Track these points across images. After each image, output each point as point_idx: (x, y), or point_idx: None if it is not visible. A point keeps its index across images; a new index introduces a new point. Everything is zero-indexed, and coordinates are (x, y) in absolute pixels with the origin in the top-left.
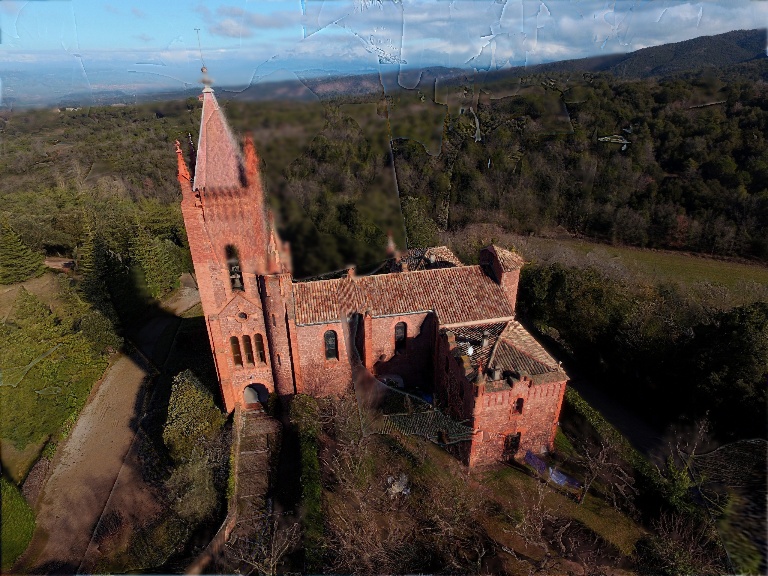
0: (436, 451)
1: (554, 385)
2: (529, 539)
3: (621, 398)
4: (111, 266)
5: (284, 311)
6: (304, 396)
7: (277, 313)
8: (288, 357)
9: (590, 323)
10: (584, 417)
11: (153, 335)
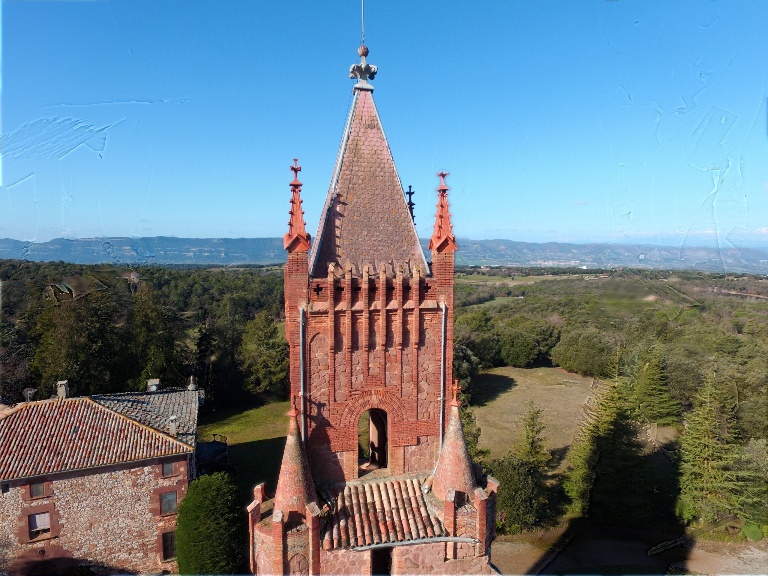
0: None
1: None
2: None
3: None
4: (619, 431)
5: None
6: None
7: None
8: None
9: None
10: None
11: (599, 557)
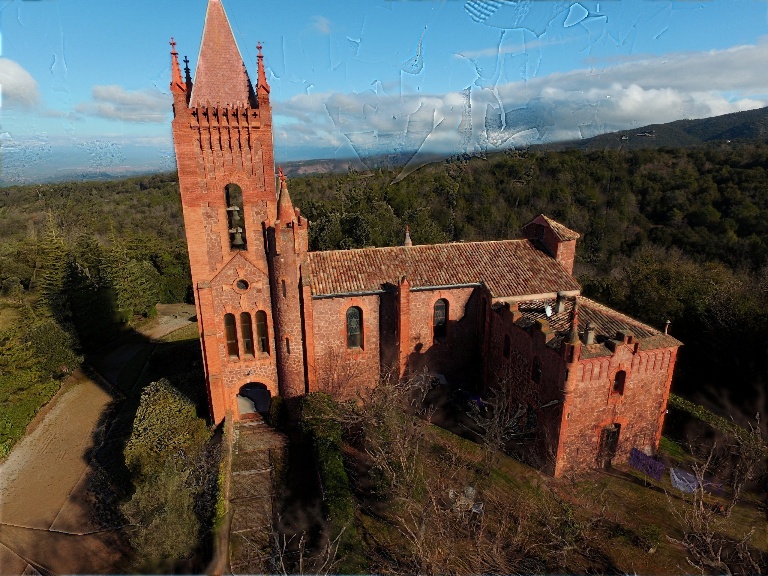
0: (503, 460)
1: (663, 353)
2: (700, 555)
3: (711, 399)
4: (76, 279)
5: (297, 276)
6: (320, 393)
7: (288, 278)
8: (300, 342)
9: (662, 307)
10: (686, 412)
11: (121, 361)
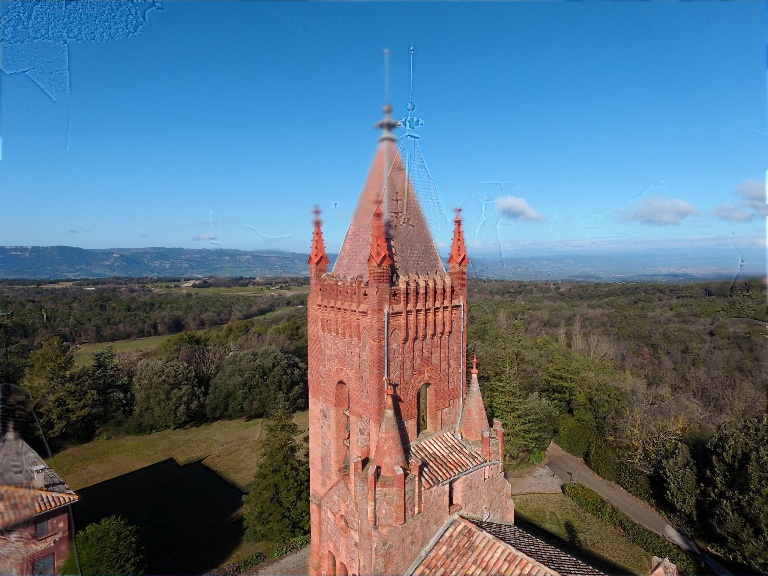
0: None
1: None
2: None
3: None
4: None
5: (373, 561)
6: None
7: (362, 556)
8: None
9: None
10: None
11: None
